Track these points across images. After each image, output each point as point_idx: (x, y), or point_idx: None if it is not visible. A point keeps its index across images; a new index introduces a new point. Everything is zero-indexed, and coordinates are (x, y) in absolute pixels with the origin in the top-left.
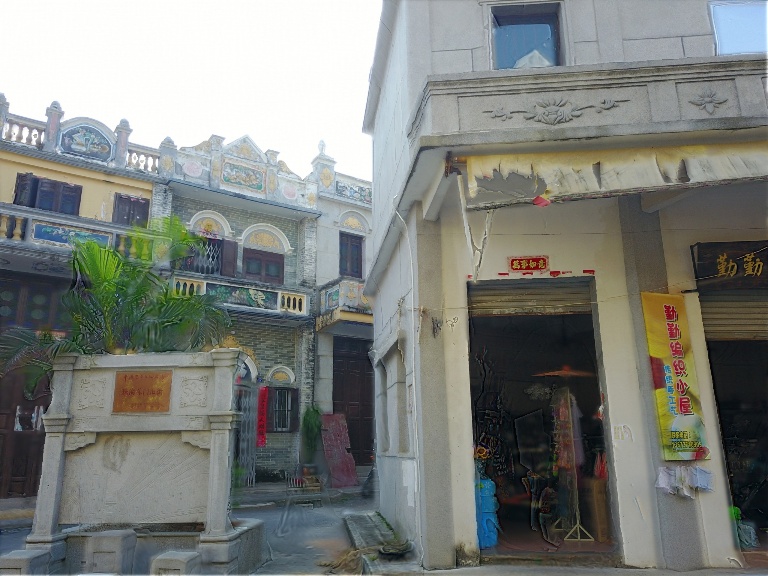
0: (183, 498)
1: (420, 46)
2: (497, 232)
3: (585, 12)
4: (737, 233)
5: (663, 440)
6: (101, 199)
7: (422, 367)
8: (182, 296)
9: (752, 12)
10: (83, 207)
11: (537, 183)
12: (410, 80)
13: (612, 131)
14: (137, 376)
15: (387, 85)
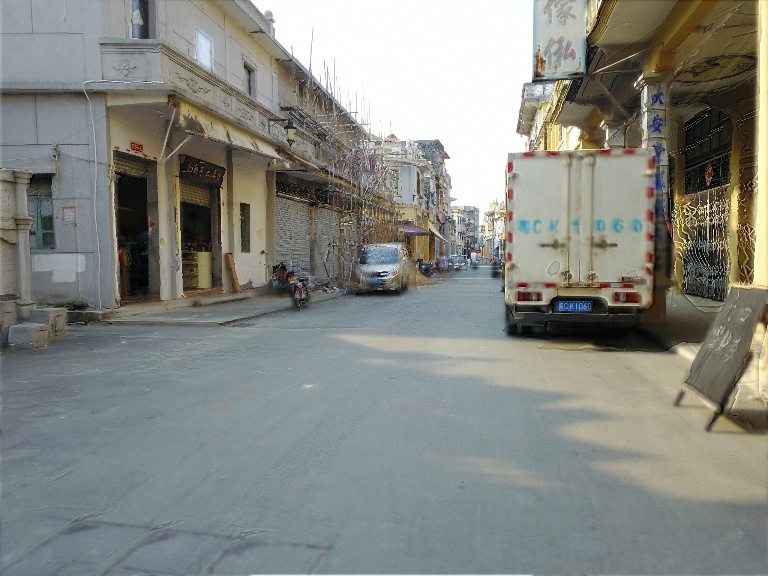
0: None
1: None
2: (131, 125)
3: None
4: (196, 154)
5: (176, 245)
6: None
7: None
8: None
9: (205, 43)
10: None
11: (199, 126)
12: (101, 1)
13: (218, 111)
14: None
15: None
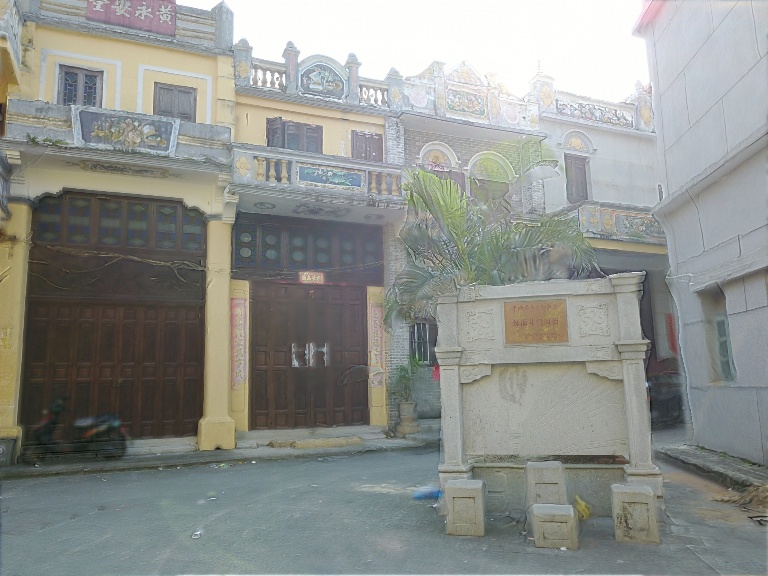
0: (595, 430)
1: None
2: None
3: None
4: None
5: None
6: (340, 138)
7: None
8: None
9: None
10: (325, 147)
11: None
12: None
13: None
14: (527, 306)
15: None
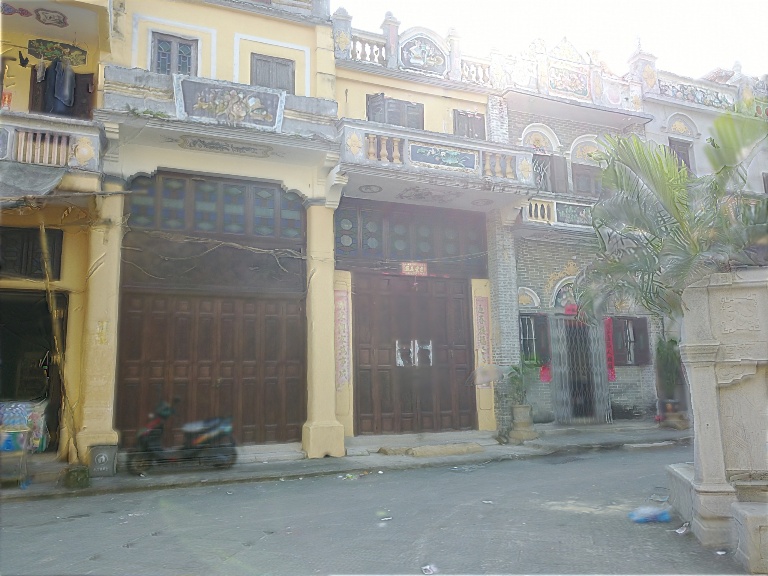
0: None
1: None
2: None
3: None
4: None
5: None
6: (441, 117)
7: None
8: (535, 219)
9: None
10: (427, 127)
11: None
12: None
13: None
14: None
15: None
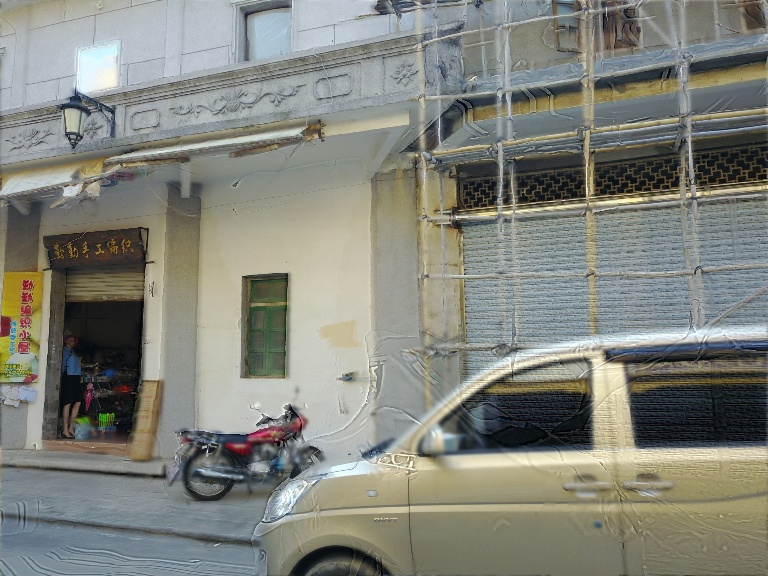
0: None
1: None
2: None
3: (10, 64)
4: (60, 229)
5: None
6: None
7: None
8: None
9: (103, 53)
10: None
11: None
12: None
13: None
14: None
15: None
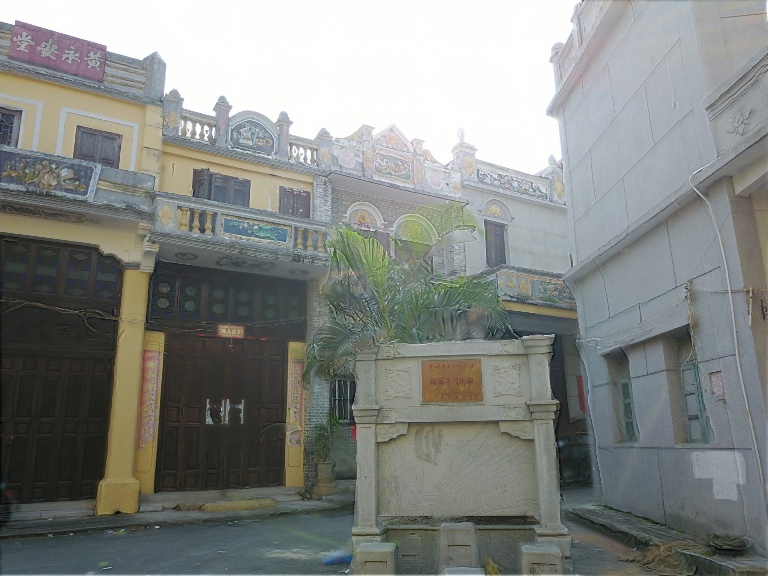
0: (508, 490)
1: (707, 13)
2: None
3: None
4: None
5: None
6: (268, 193)
7: (757, 352)
8: None
9: None
10: (252, 201)
11: None
12: (701, 49)
13: None
14: (444, 365)
15: (615, 61)
